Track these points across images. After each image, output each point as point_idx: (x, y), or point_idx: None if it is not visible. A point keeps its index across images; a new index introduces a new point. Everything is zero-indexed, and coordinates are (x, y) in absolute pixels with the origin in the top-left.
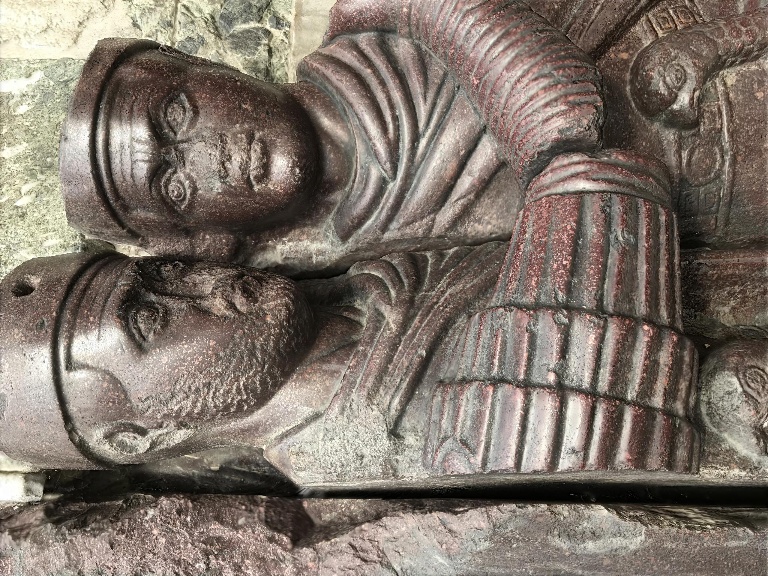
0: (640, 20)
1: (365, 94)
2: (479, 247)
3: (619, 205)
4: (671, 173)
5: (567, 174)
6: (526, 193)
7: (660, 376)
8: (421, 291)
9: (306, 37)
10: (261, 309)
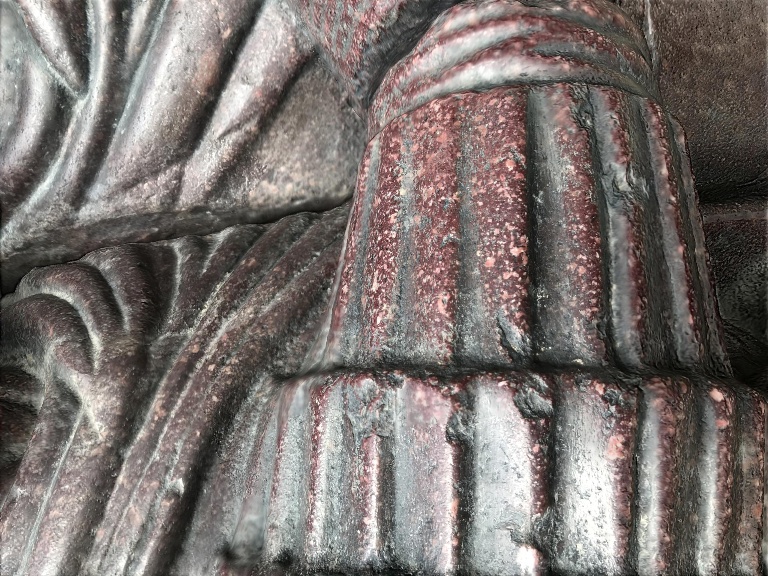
0: None
1: None
2: (275, 225)
3: (611, 109)
4: None
5: (481, 44)
6: (373, 104)
7: (746, 501)
8: (163, 329)
9: None
10: None
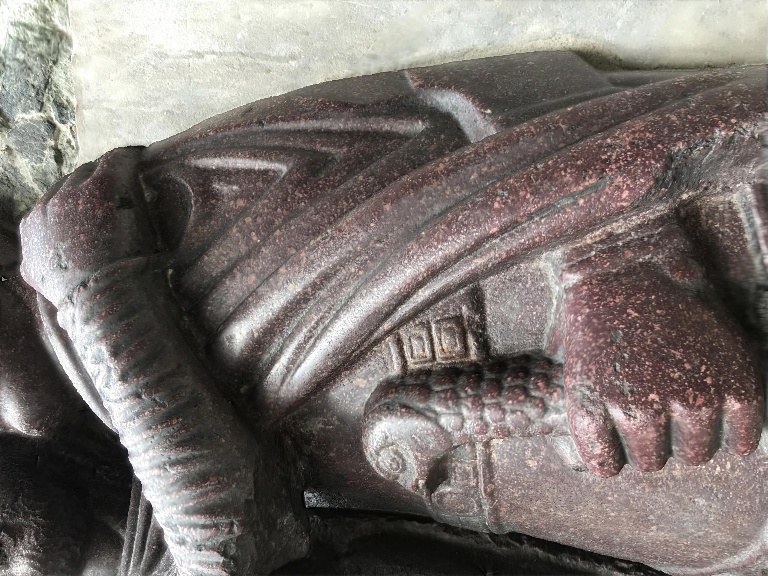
0: (385, 340)
1: (76, 373)
2: None
3: None
4: (422, 501)
5: None
6: None
7: None
8: (156, 568)
9: (91, 143)
10: (12, 575)
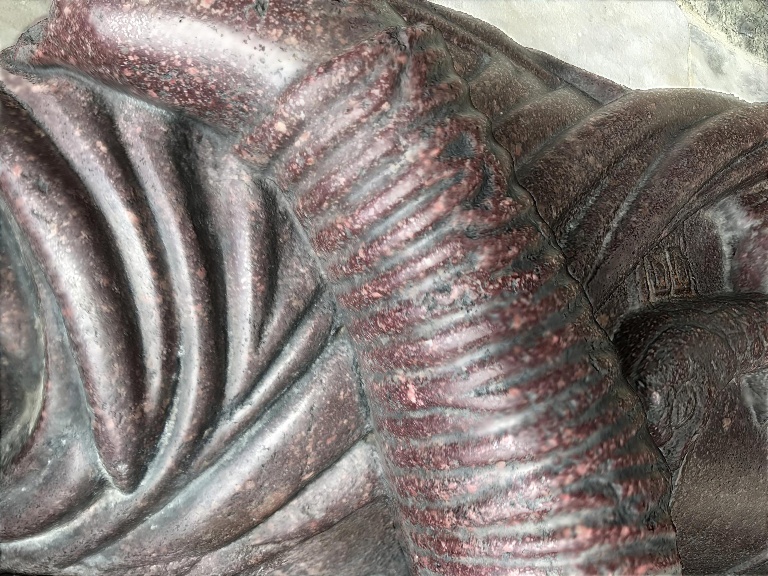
0: None
1: (107, 286)
2: None
3: None
4: None
5: None
6: None
7: None
8: None
9: None
10: None
